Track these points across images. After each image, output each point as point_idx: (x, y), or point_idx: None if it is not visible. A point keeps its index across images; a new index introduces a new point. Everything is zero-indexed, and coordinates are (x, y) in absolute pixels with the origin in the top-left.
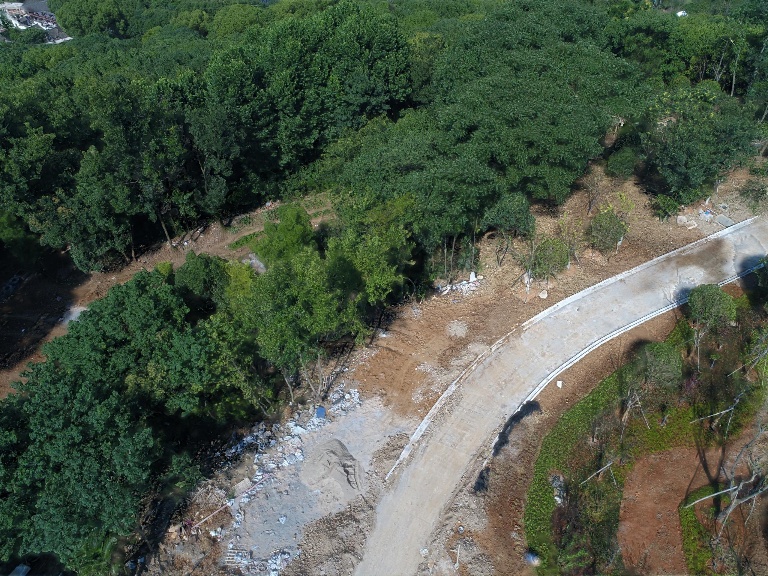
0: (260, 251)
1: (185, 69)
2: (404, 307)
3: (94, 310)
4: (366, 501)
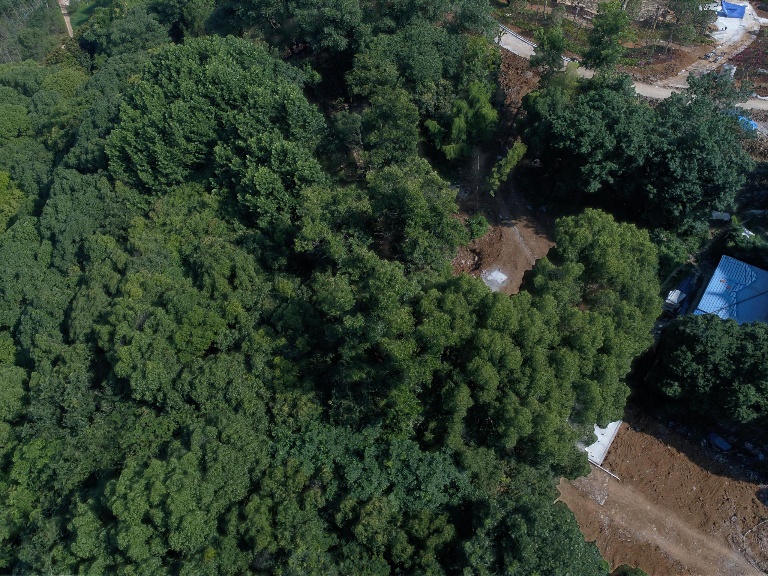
0: (494, 114)
1: (100, 233)
2: (507, 95)
3: (596, 134)
4: (640, 99)
